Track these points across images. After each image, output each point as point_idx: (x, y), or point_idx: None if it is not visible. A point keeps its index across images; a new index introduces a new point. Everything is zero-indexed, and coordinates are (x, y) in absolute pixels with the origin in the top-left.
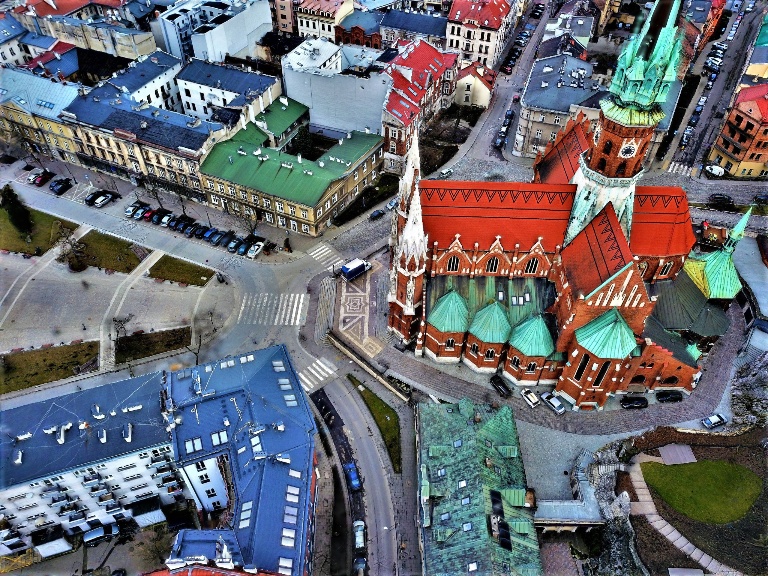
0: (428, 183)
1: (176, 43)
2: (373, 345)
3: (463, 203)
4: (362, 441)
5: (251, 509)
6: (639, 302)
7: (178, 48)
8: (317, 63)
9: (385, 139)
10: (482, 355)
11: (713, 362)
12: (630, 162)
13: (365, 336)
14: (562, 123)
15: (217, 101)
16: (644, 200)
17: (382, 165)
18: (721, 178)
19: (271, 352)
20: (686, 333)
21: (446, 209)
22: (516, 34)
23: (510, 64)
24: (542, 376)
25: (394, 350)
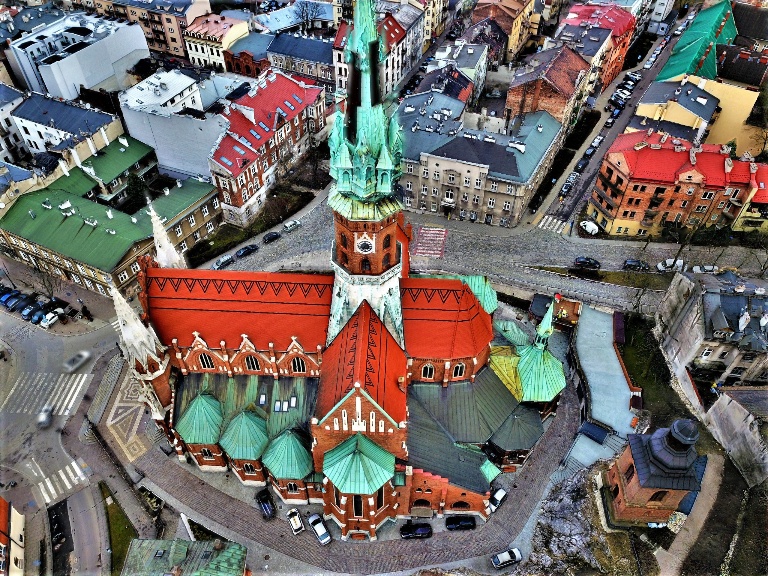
0: (158, 271)
1: (32, 73)
2: (137, 445)
3: (202, 295)
4: (86, 573)
5: None
6: (385, 428)
7: (35, 78)
8: (161, 100)
9: (218, 189)
10: (240, 469)
11: (527, 476)
12: (372, 258)
13: (132, 433)
14: (416, 172)
15: (55, 140)
16: (417, 294)
17: (222, 215)
18: (594, 237)
19: None
20: (486, 445)
21: (183, 301)
22: (424, 59)
23: (405, 94)
24: (311, 495)
25: (159, 452)
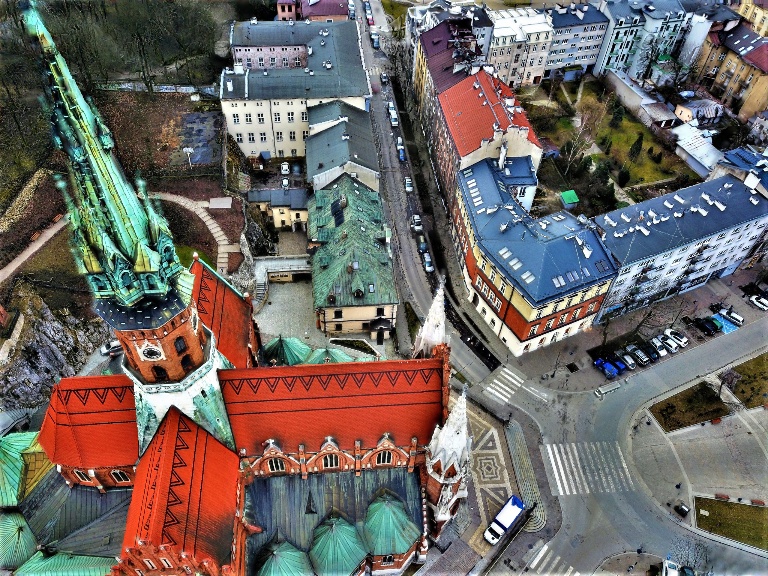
0: None
1: None
2: None
3: None
4: None
5: (500, 186)
6: None
7: None
8: None
9: None
10: None
11: None
12: None
13: None
14: None
15: None
16: None
17: None
18: None
19: (541, 289)
20: None
21: None
22: None
23: None
24: None
25: None
